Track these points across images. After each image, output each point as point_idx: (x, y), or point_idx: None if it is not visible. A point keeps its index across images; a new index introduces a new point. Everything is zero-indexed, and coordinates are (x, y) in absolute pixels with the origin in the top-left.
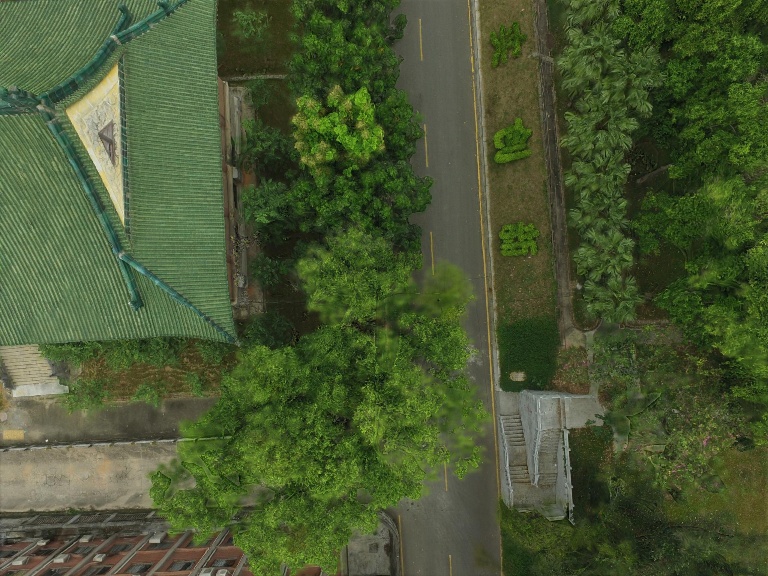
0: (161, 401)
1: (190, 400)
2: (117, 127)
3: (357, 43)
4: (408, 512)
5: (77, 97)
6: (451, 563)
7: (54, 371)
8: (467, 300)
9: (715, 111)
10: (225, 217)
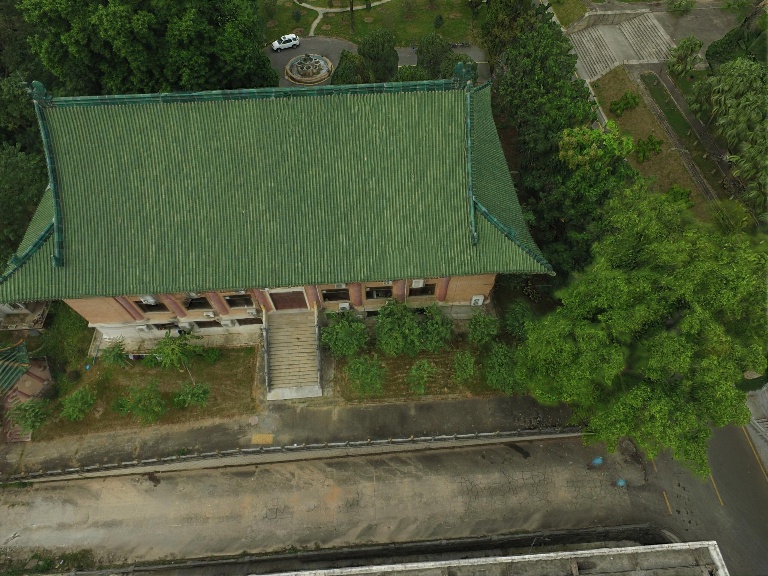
0: (410, 404)
1: (438, 403)
2: None
3: None
4: (688, 532)
5: None
6: None
7: (319, 367)
8: None
9: None
10: None
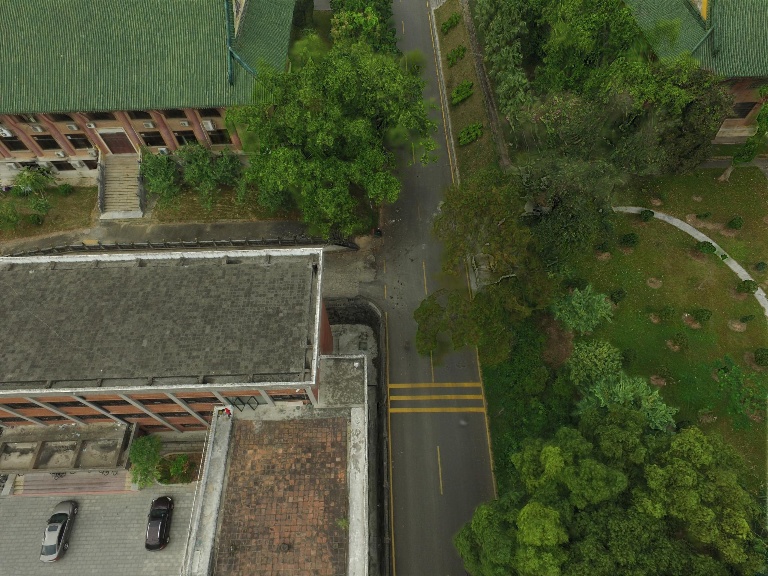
0: (208, 224)
1: (230, 224)
2: None
3: None
4: (394, 310)
5: None
6: (432, 352)
7: (139, 194)
8: None
9: None
10: None
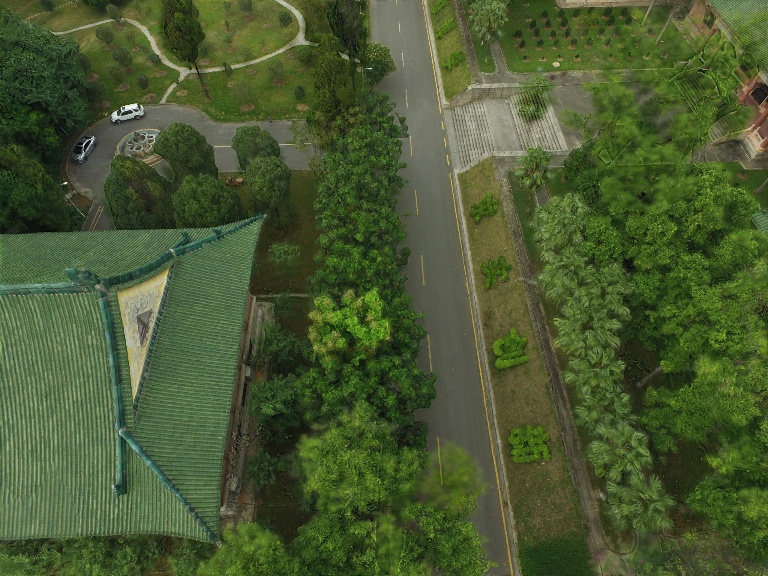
0: None
1: None
2: (154, 315)
3: (369, 262)
4: None
5: (130, 284)
6: None
7: None
8: (477, 489)
9: (685, 309)
10: (231, 412)
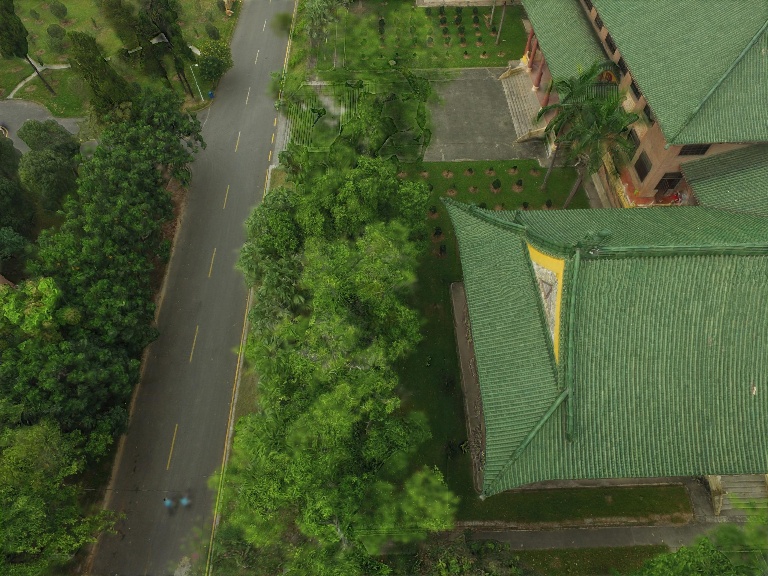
0: None
1: None
2: None
3: None
4: None
5: None
6: None
7: None
8: (46, 465)
9: None
10: None
